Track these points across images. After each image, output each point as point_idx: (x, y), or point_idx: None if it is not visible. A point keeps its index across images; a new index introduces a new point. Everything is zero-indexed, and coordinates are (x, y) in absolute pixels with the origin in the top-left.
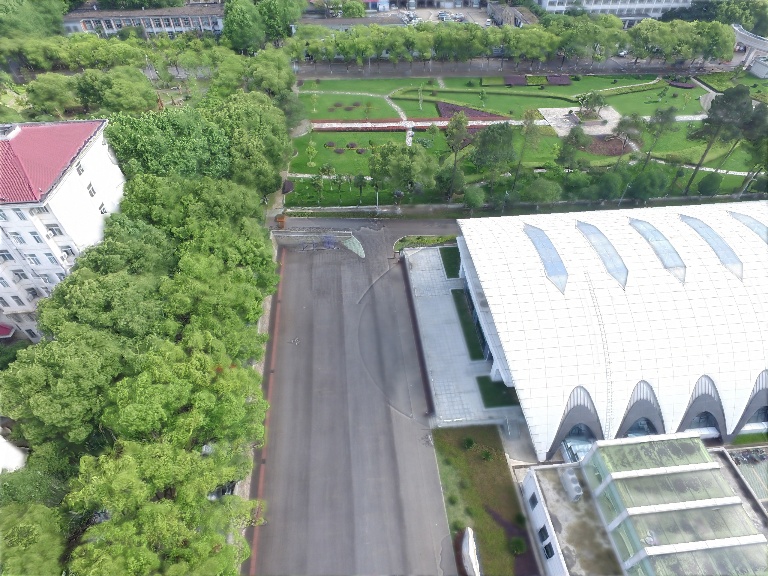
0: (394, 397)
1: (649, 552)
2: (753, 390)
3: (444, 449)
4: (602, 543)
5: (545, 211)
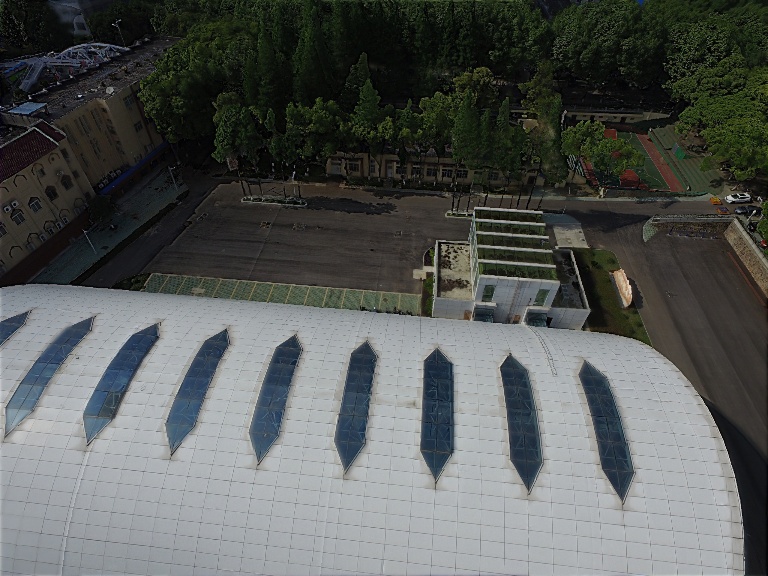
0: None
1: None
2: None
3: None
4: None
5: None
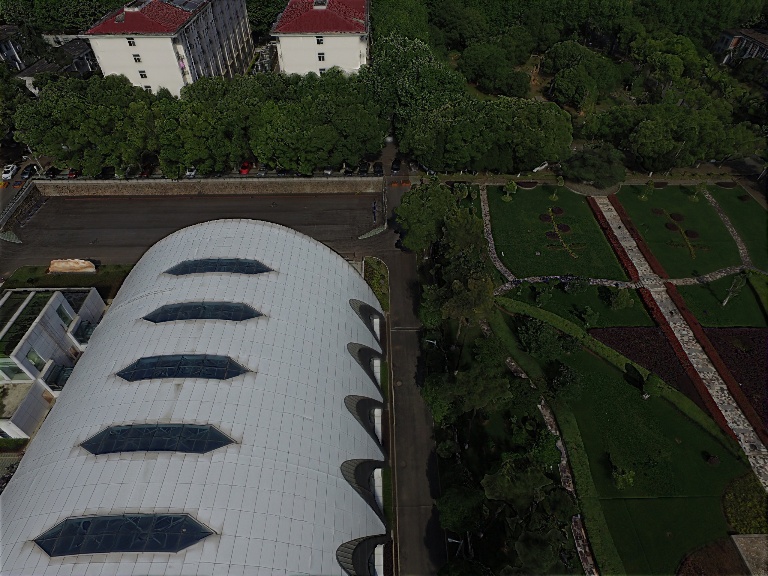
0: None
1: None
2: None
3: None
4: None
5: None
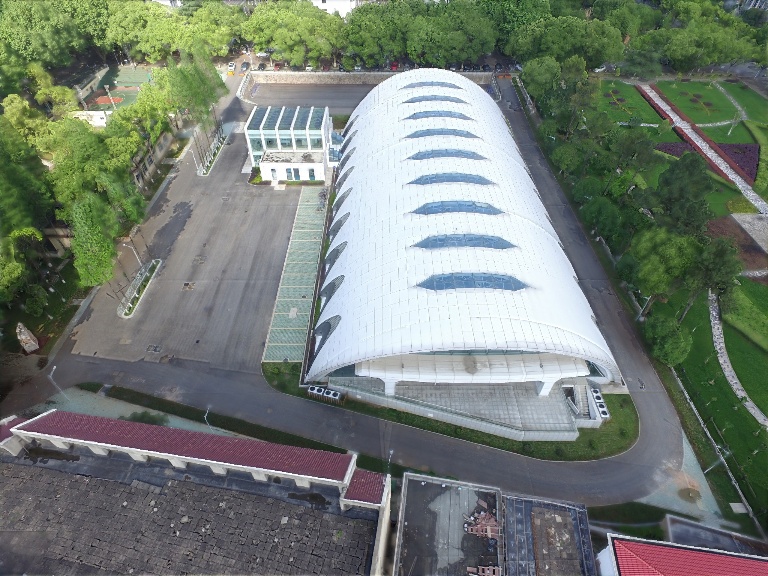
0: None
1: None
2: None
3: None
4: None
5: (558, 176)
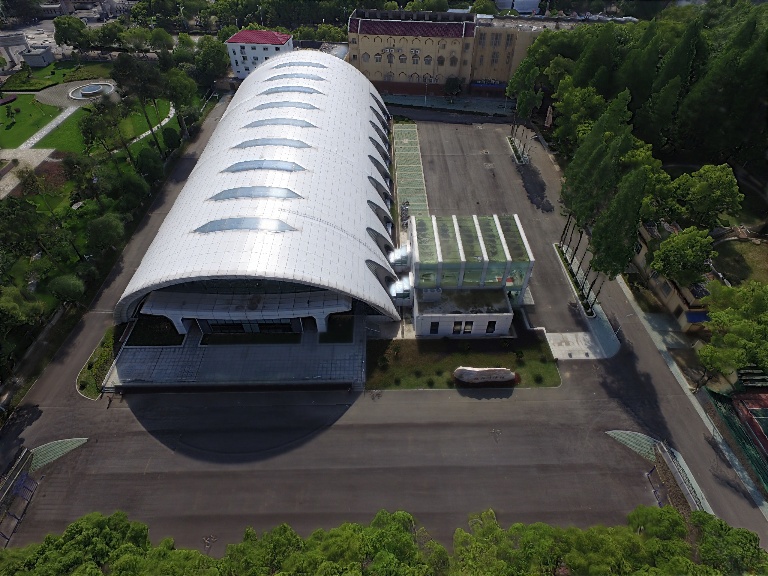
0: (324, 420)
1: (487, 260)
2: (376, 190)
3: (386, 381)
4: (467, 293)
5: (123, 245)
